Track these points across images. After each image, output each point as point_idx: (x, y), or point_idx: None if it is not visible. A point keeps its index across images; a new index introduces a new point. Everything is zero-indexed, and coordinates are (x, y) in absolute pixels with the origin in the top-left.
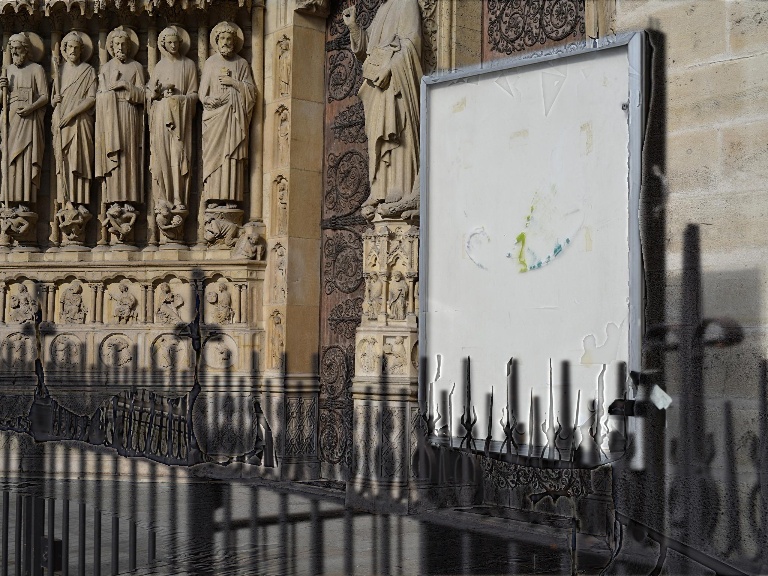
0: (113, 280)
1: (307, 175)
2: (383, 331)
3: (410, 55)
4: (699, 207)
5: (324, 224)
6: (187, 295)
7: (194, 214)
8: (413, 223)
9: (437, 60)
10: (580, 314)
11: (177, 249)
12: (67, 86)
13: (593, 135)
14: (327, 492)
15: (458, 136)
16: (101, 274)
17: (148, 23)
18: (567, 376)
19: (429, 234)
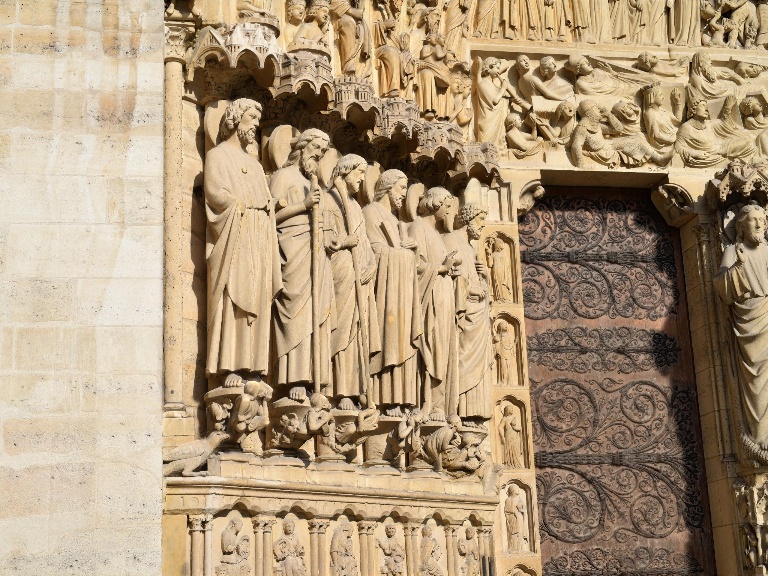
0: None
1: None
2: None
3: None
4: None
5: None
6: (441, 542)
7: None
8: None
9: None
10: None
11: None
12: (357, 225)
13: None
14: None
15: None
16: (380, 508)
17: None
18: None
19: None
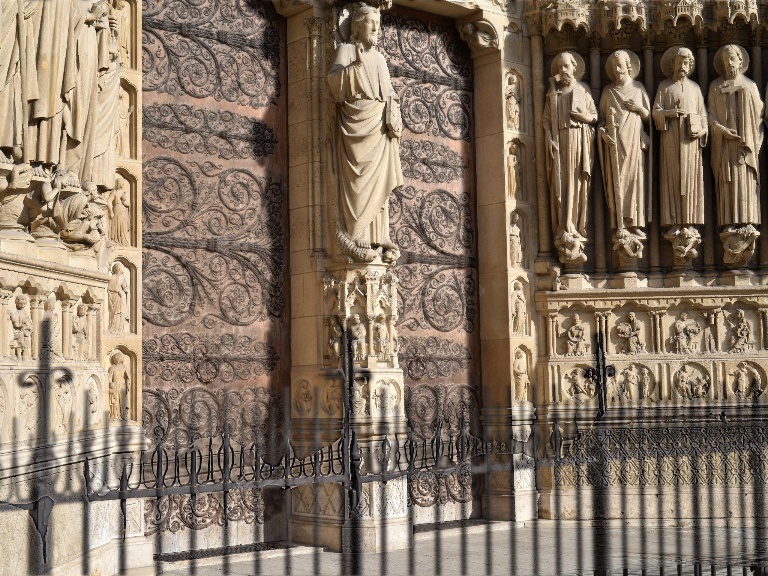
0: None
1: None
2: None
3: None
4: None
5: None
6: None
7: None
8: None
9: None
10: None
11: None
12: None
13: None
14: (260, 555)
15: None
16: (17, 276)
17: None
18: None
19: None
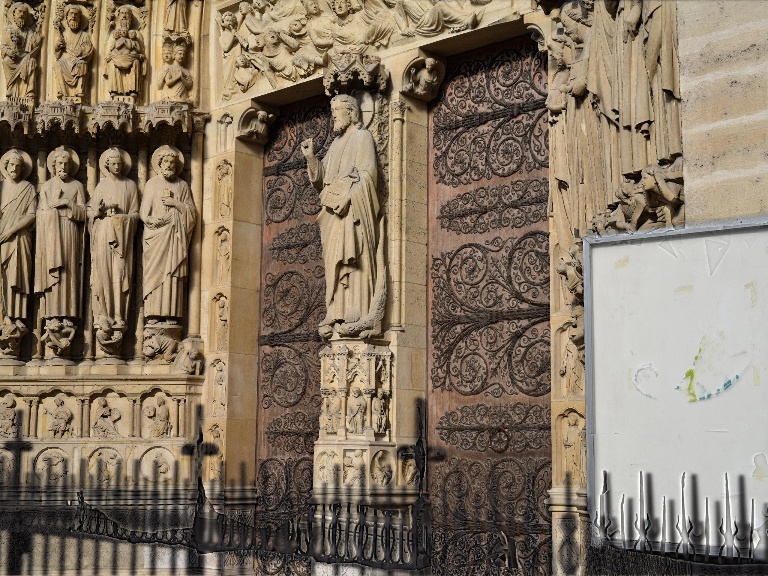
0: (48, 394)
1: (246, 293)
2: (343, 445)
3: (368, 186)
4: None
5: (261, 340)
6: (124, 409)
7: (132, 329)
8: (370, 342)
9: (389, 190)
10: (750, 437)
11: (116, 364)
12: (7, 203)
13: (757, 292)
14: None
15: (622, 288)
16: (37, 388)
17: (88, 144)
18: (742, 488)
19: (595, 368)
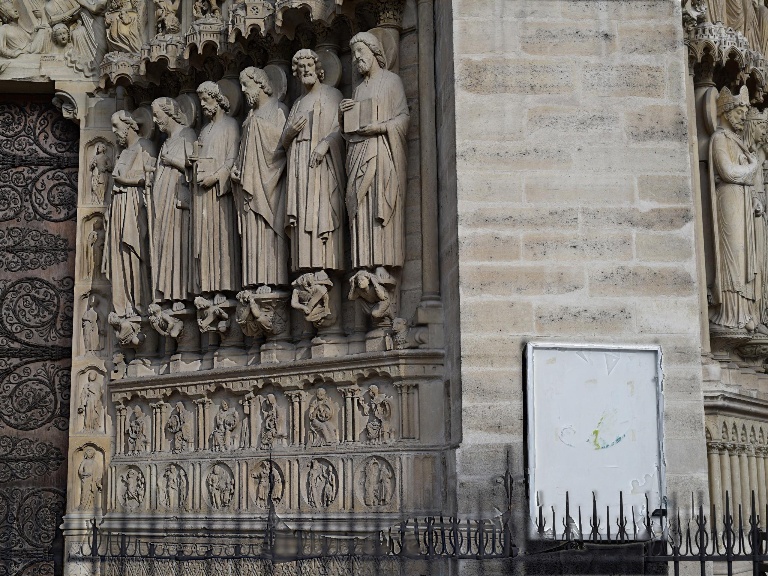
0: None
1: None
2: None
3: None
4: (519, 410)
5: None
6: None
7: None
8: None
9: None
10: (631, 470)
11: None
12: None
13: (635, 387)
14: None
15: (552, 377)
16: None
17: None
18: None
19: (535, 426)
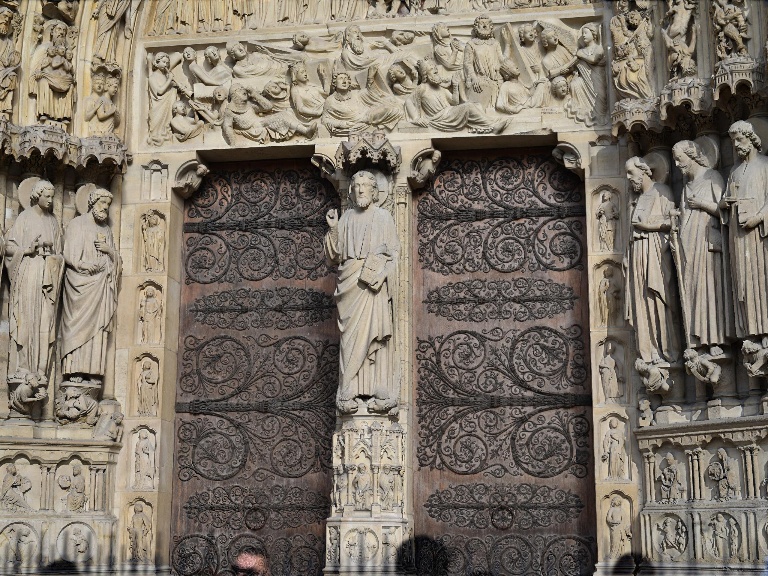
0: None
1: (171, 355)
2: (381, 522)
3: None
4: None
5: (179, 407)
6: (35, 478)
7: None
8: (392, 419)
9: None
10: None
11: (31, 425)
12: None
13: None
14: None
15: None
16: None
17: None
18: None
19: None
